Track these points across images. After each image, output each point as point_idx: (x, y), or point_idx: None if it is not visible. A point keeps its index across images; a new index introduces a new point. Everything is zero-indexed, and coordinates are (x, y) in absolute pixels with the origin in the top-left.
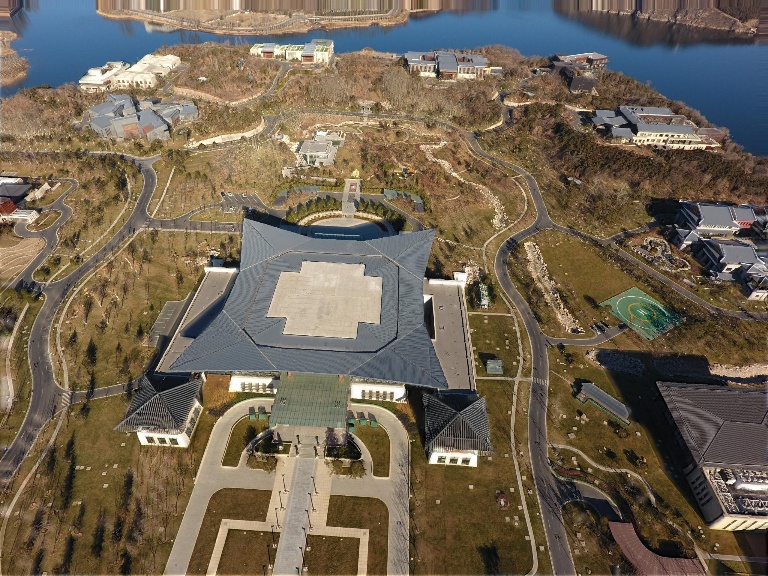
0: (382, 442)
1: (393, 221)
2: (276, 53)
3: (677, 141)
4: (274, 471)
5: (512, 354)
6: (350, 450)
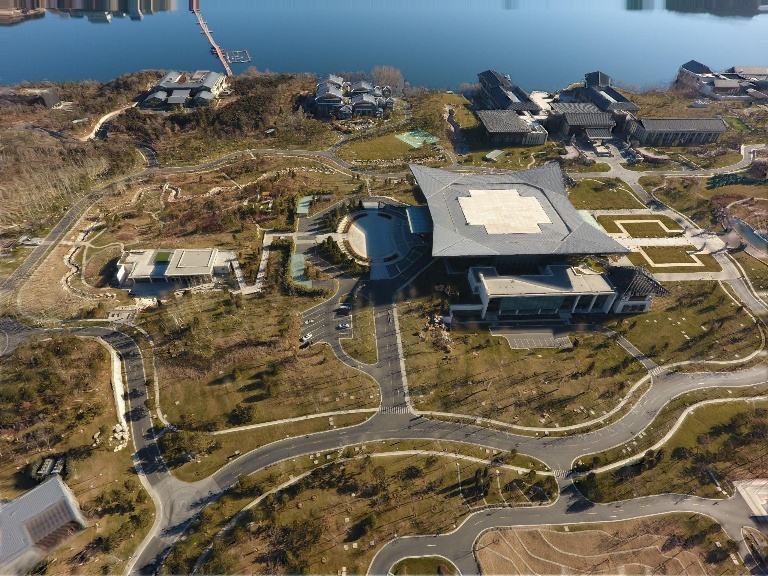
0: None
1: (354, 208)
2: None
3: None
4: None
5: None
6: None
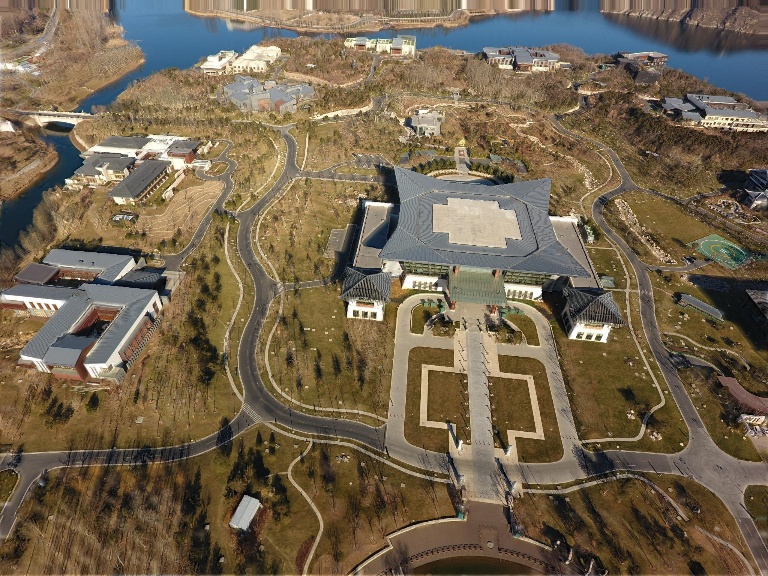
0: (529, 325)
1: (503, 178)
2: (367, 46)
3: (741, 125)
4: (453, 337)
5: (620, 274)
6: (506, 328)
